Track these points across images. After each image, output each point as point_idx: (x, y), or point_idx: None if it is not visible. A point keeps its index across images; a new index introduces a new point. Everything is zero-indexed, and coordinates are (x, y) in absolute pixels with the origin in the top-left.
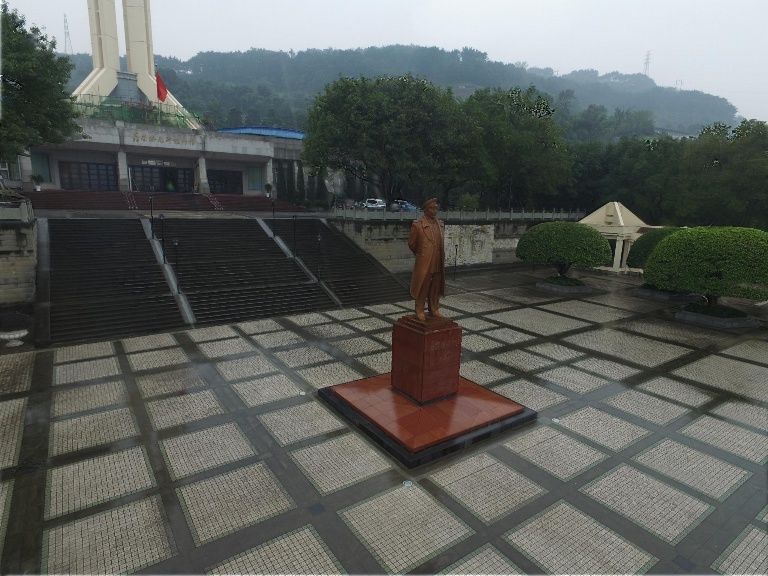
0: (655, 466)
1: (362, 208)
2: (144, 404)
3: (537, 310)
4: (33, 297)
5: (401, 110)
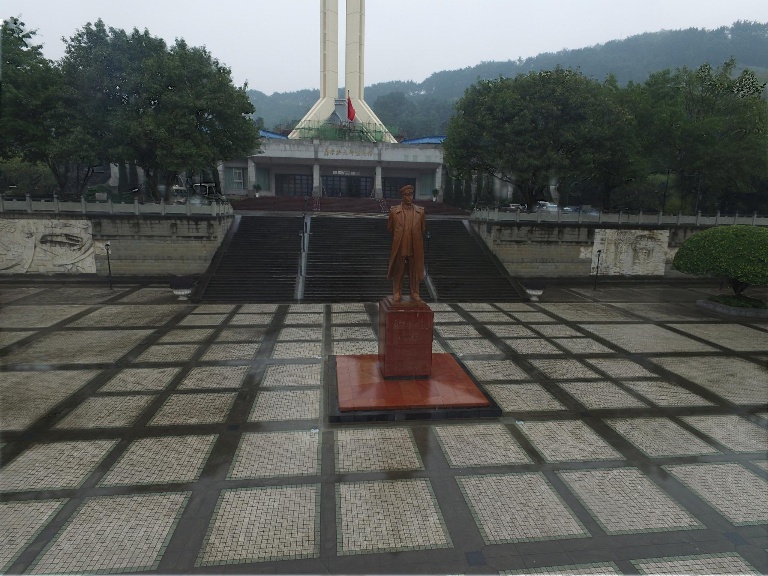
0: (575, 484)
1: (494, 209)
2: (211, 344)
3: (660, 327)
4: (206, 269)
5: (531, 106)
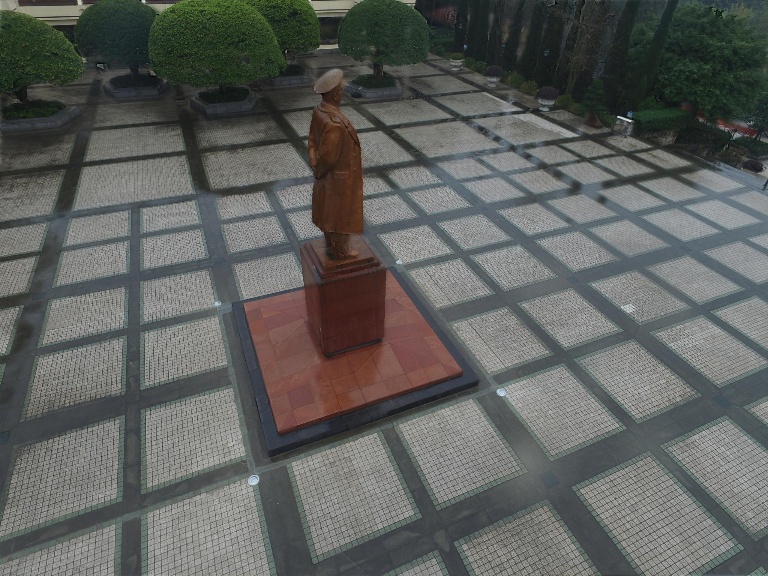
0: (474, 245)
1: None
2: None
3: (100, 166)
4: None
5: None
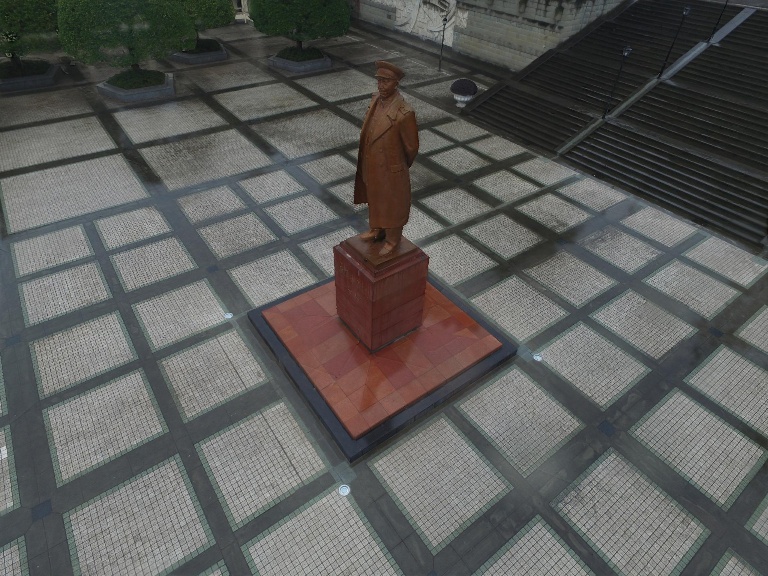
0: None
1: None
2: None
3: None
4: (517, 73)
5: None
